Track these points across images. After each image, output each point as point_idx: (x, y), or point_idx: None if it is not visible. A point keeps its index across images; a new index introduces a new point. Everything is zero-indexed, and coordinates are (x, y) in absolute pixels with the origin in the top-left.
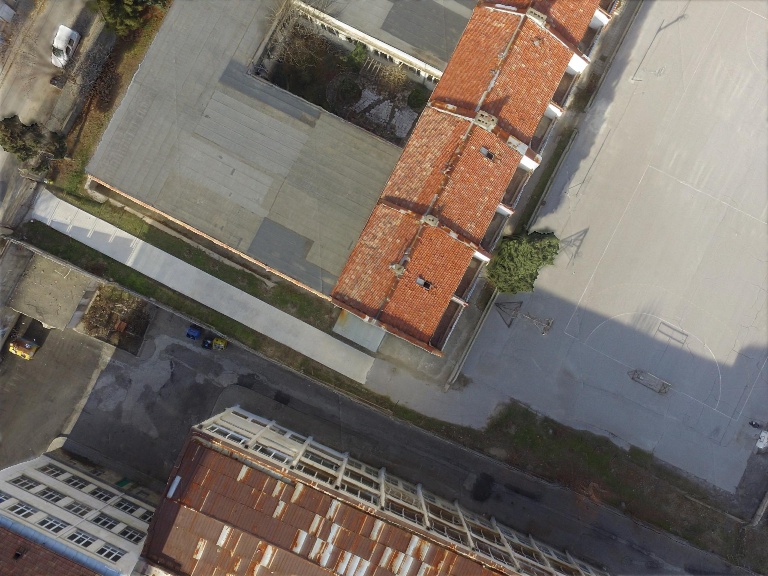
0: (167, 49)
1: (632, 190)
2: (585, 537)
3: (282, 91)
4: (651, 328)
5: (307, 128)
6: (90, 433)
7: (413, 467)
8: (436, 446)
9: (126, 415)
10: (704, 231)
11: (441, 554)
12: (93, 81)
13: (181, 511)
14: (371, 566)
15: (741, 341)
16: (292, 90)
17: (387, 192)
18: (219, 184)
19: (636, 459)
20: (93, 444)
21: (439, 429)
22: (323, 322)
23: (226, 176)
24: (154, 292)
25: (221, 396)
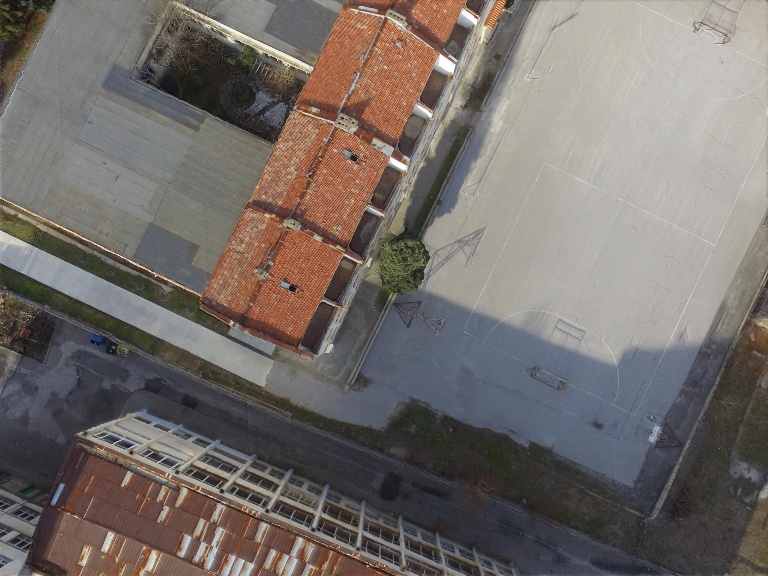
0: (50, 55)
1: (529, 188)
2: (492, 534)
3: (166, 96)
4: (549, 325)
5: (191, 132)
6: None
7: (321, 468)
8: (344, 447)
9: (33, 422)
10: (600, 228)
11: (325, 555)
12: None
13: (65, 518)
14: (255, 568)
15: (638, 336)
16: (186, 94)
17: (255, 196)
18: (104, 190)
19: (535, 456)
20: (0, 452)
21: (339, 430)
22: (221, 326)
23: (110, 182)
24: (49, 299)
25: (128, 401)
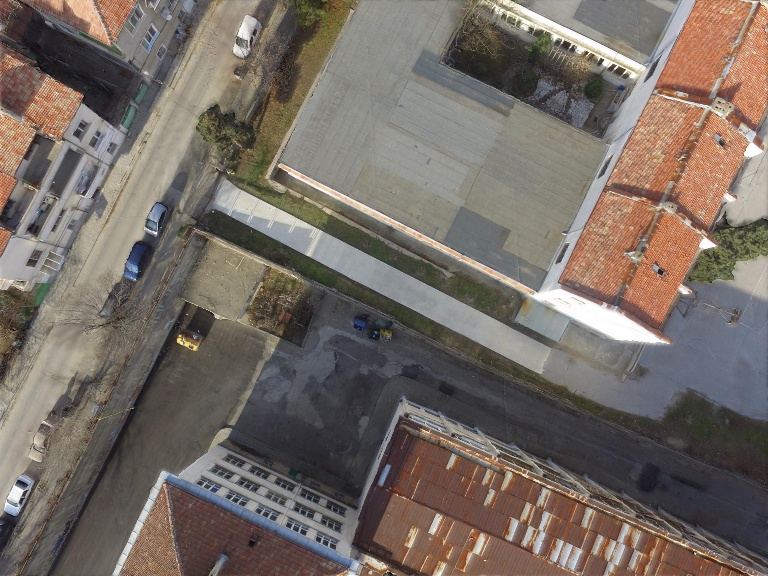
0: (359, 39)
1: None
2: (752, 527)
3: (475, 81)
4: None
5: (501, 117)
6: (255, 424)
7: (579, 457)
8: (601, 436)
9: (291, 406)
10: None
11: (652, 541)
12: (274, 71)
13: (392, 499)
14: (583, 554)
15: None
16: None
17: (614, 179)
18: (415, 173)
19: None
20: (258, 435)
21: (617, 419)
22: (500, 312)
23: (422, 165)
24: (334, 282)
25: (386, 387)
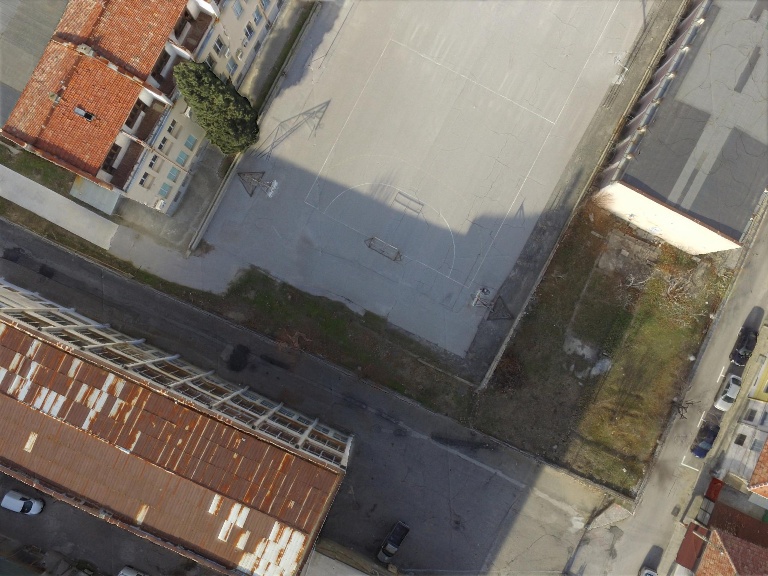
0: None
1: (374, 63)
2: (336, 406)
3: None
4: (388, 198)
5: None
6: None
7: (172, 338)
8: (195, 319)
9: None
10: (443, 104)
11: (136, 391)
12: None
13: None
14: (67, 401)
15: (475, 211)
16: None
17: (58, 28)
18: None
19: (371, 324)
20: None
21: (180, 293)
22: (67, 189)
23: None
24: None
25: None
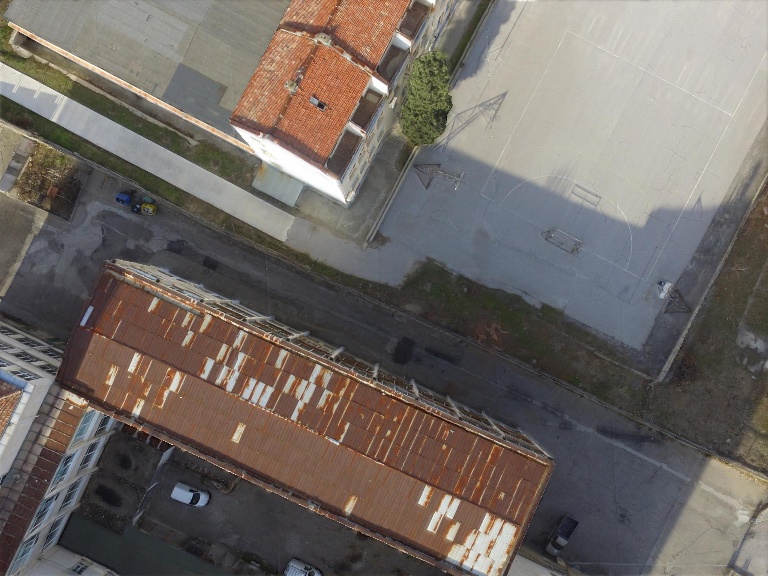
0: None
1: (551, 55)
2: (502, 399)
3: None
4: (565, 190)
5: None
6: (24, 295)
7: (337, 331)
8: (359, 311)
9: (59, 278)
10: (620, 96)
11: (343, 382)
12: None
13: (94, 339)
14: (275, 392)
15: (653, 204)
16: None
17: (285, 18)
18: (135, 30)
19: (547, 317)
20: (27, 306)
21: (357, 286)
22: (245, 181)
23: (141, 22)
24: (78, 147)
25: (151, 261)
